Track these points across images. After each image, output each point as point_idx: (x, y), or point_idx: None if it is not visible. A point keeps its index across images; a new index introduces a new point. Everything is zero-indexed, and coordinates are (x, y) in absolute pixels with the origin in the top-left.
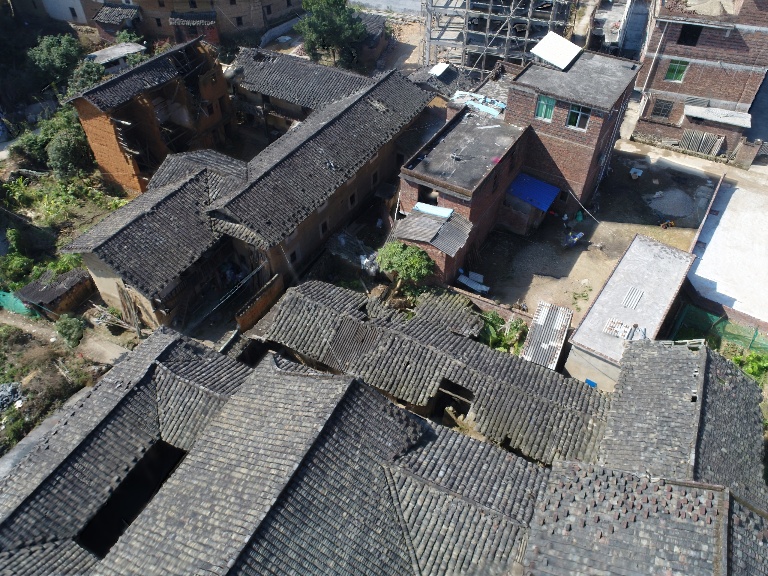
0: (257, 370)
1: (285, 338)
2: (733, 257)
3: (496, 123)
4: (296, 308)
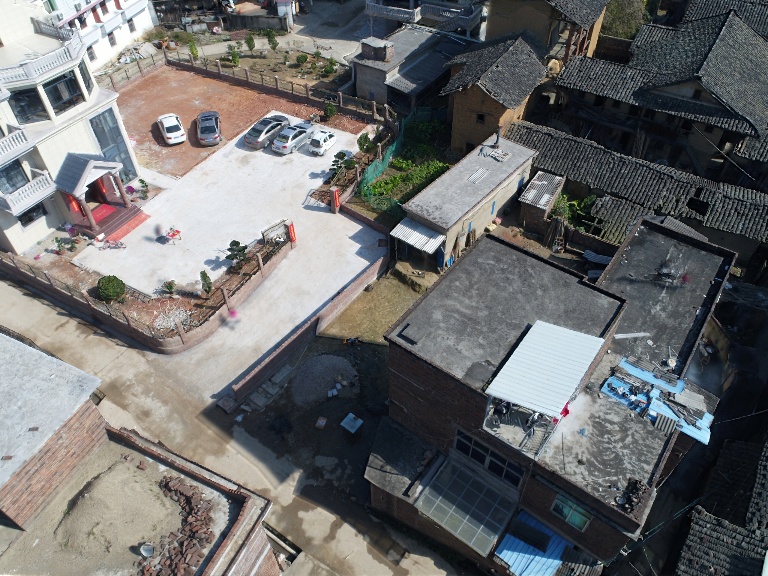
0: (763, 129)
1: (760, 194)
2: (316, 280)
3: (621, 344)
4: (766, 202)
